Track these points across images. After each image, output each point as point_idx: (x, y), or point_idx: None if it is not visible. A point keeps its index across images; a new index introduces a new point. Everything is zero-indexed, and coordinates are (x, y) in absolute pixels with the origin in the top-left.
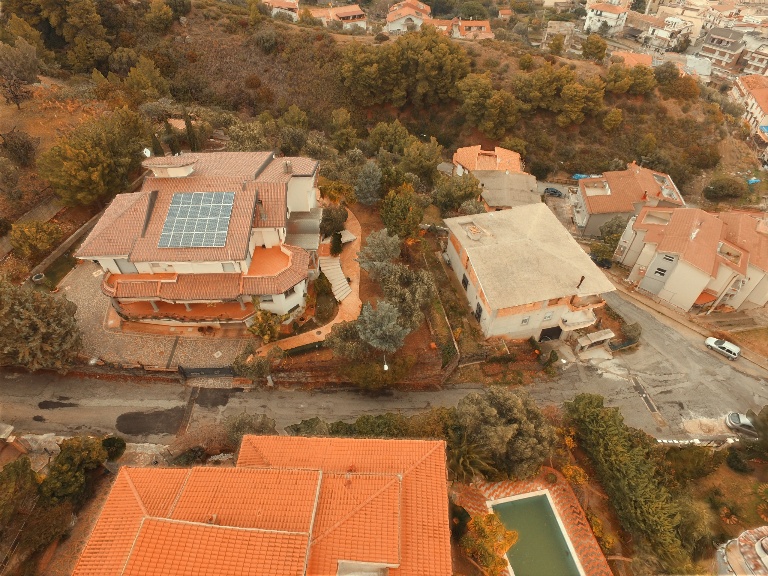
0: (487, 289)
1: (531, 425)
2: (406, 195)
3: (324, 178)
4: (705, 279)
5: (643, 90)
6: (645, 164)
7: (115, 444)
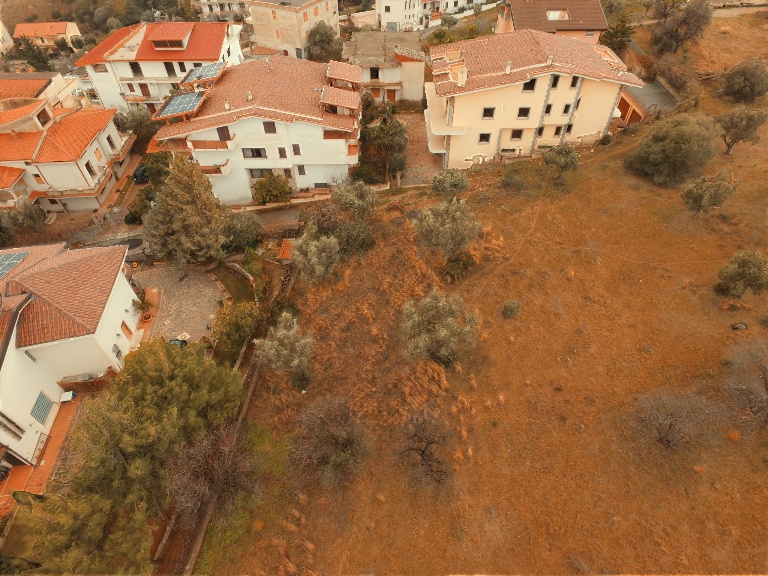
0: None
1: None
2: None
3: None
4: None
5: None
6: None
7: None
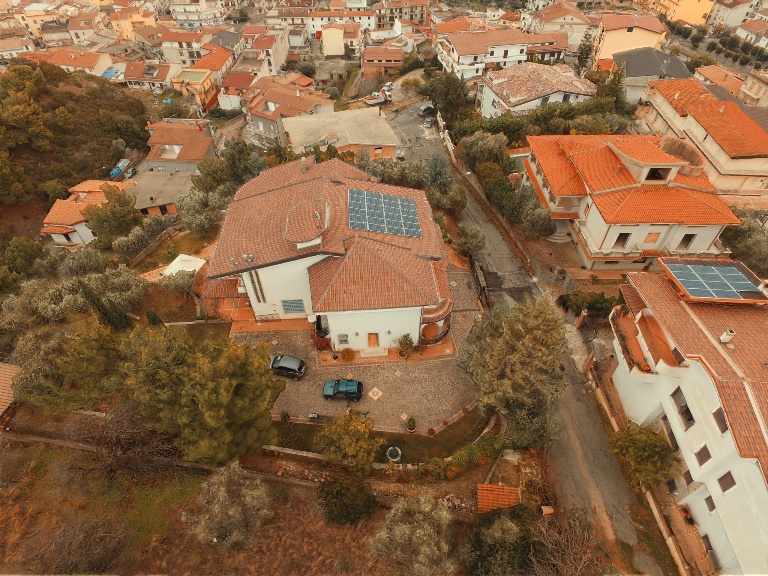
0: (386, 143)
1: (489, 133)
2: (290, 154)
3: (187, 243)
4: (331, 106)
5: (44, 86)
6: (125, 133)
7: (564, 298)
